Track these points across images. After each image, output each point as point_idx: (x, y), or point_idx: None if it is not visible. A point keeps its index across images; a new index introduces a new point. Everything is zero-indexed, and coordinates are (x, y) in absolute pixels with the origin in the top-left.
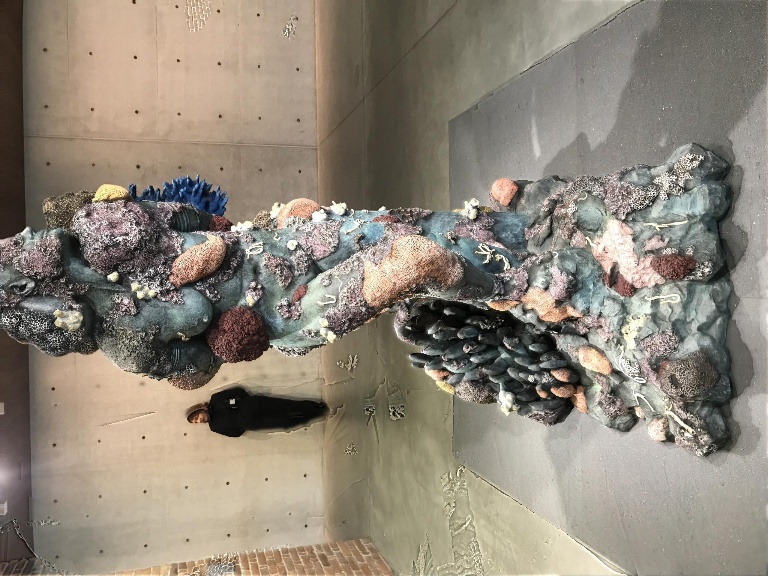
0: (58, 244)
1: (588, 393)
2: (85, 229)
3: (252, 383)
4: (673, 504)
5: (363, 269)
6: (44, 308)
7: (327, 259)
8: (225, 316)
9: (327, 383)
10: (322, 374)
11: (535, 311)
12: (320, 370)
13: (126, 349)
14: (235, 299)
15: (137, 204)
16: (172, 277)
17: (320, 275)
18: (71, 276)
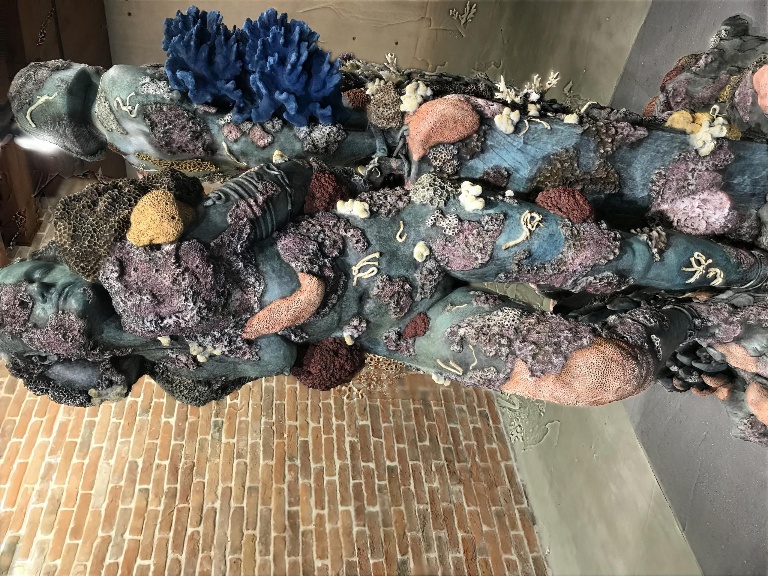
0: (81, 326)
1: (733, 393)
2: (118, 302)
3: (347, 11)
4: (759, 536)
5: (512, 368)
6: (75, 383)
7: (466, 272)
8: (313, 355)
9: (433, 26)
10: (430, 13)
11: (723, 354)
12: (428, 7)
13: (185, 398)
14: (328, 333)
15: (196, 242)
16: (245, 334)
17: (450, 311)
18: (106, 343)
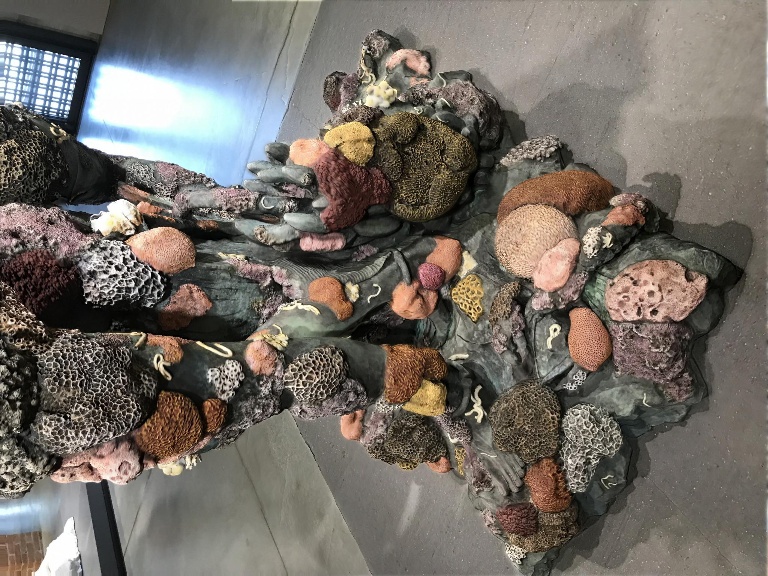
0: None
1: None
2: None
3: None
4: None
5: None
6: None
7: None
8: None
9: None
10: None
11: None
12: None
13: None
14: None
15: None
16: None
17: None
18: None
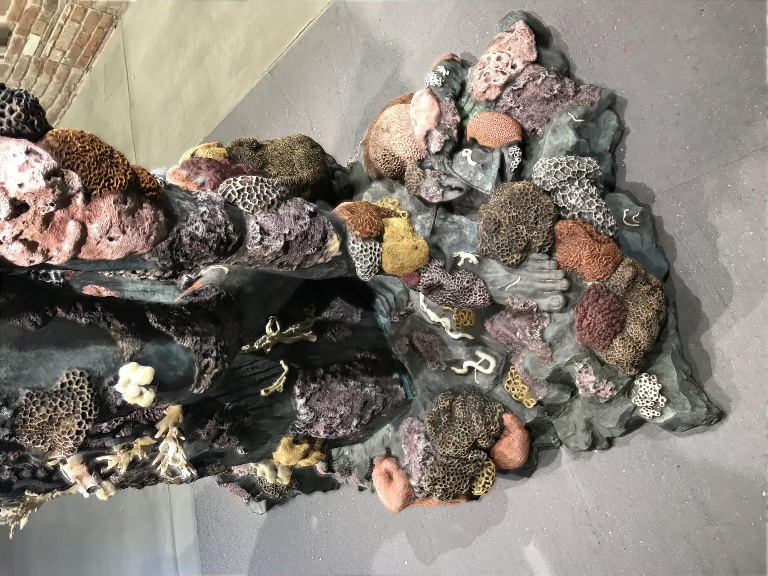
0: None
1: None
2: None
3: None
4: None
5: None
6: None
7: None
8: None
9: None
10: None
11: None
12: None
13: None
14: None
15: None
16: None
17: None
18: None
